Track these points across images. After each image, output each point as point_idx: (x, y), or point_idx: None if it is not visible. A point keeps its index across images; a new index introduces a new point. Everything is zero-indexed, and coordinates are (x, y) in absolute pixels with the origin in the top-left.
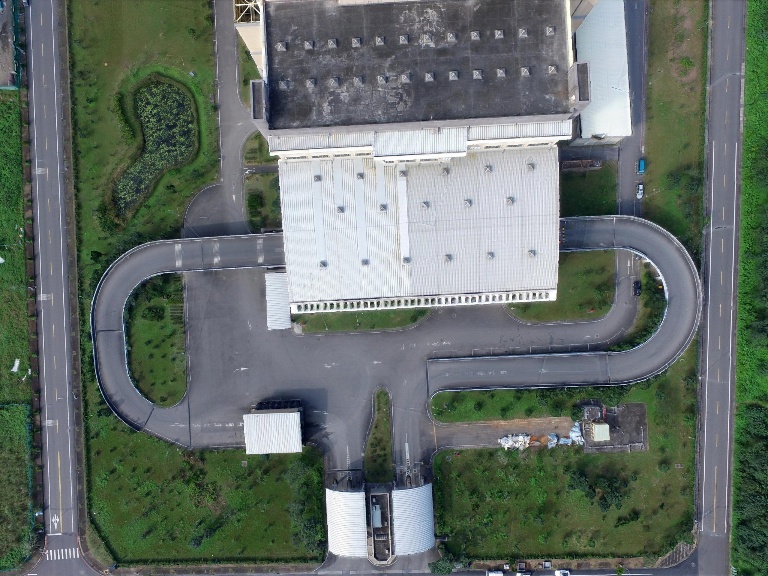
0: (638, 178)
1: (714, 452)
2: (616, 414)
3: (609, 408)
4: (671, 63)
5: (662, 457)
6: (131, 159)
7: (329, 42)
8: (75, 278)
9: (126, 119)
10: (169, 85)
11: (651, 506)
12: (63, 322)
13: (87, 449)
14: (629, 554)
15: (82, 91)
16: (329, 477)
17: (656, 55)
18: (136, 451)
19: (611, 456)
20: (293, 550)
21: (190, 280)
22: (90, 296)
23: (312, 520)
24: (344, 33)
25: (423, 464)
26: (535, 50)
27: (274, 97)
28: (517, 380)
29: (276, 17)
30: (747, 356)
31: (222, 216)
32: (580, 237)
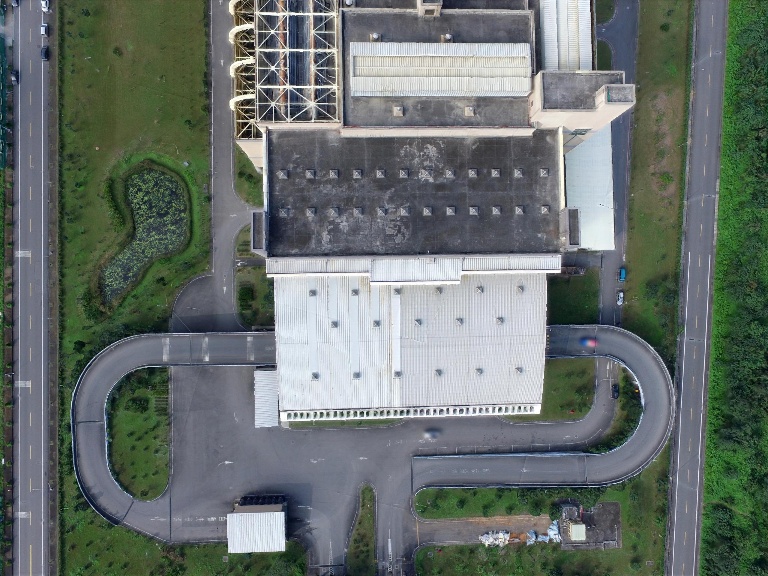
0: (619, 285)
1: (682, 550)
2: (592, 512)
3: None
4: (652, 177)
5: (634, 554)
6: (120, 246)
7: (330, 173)
8: (56, 365)
9: (116, 205)
10: (162, 173)
11: None
12: (41, 410)
13: (61, 543)
14: None
15: (71, 174)
16: (311, 573)
17: (639, 168)
18: (113, 545)
19: (586, 553)
20: None
21: (176, 371)
22: (71, 387)
23: None
24: (345, 164)
25: (405, 560)
26: (529, 190)
27: (274, 224)
28: (499, 478)
29: (279, 145)
30: (715, 458)
31: (212, 307)
32: (563, 344)
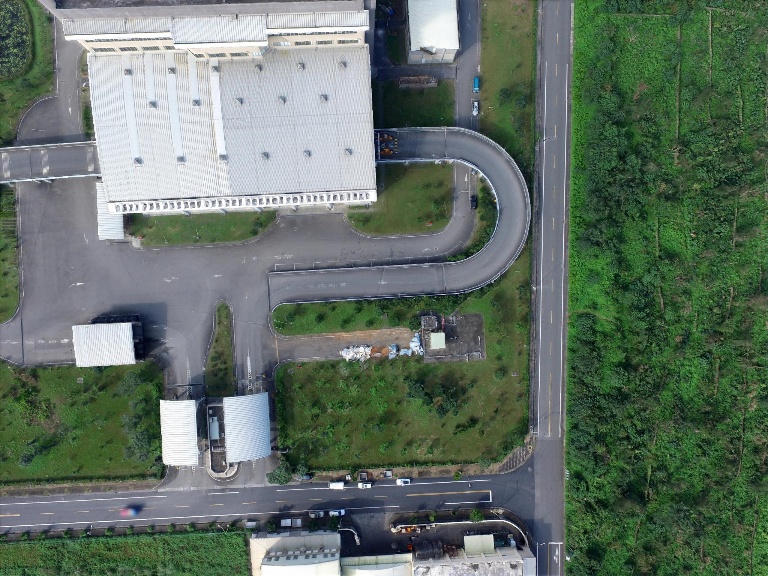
0: (474, 96)
1: (548, 360)
2: (455, 324)
3: (448, 318)
4: None
5: (499, 365)
6: None
7: None
8: None
9: None
10: None
11: (489, 413)
12: None
13: None
14: (468, 461)
15: None
16: (169, 392)
17: None
18: None
19: (450, 365)
20: (131, 467)
21: (23, 194)
22: None
23: (145, 432)
24: None
25: (265, 377)
26: None
27: None
28: (357, 292)
29: None
30: (578, 267)
31: (57, 129)
32: (412, 148)
